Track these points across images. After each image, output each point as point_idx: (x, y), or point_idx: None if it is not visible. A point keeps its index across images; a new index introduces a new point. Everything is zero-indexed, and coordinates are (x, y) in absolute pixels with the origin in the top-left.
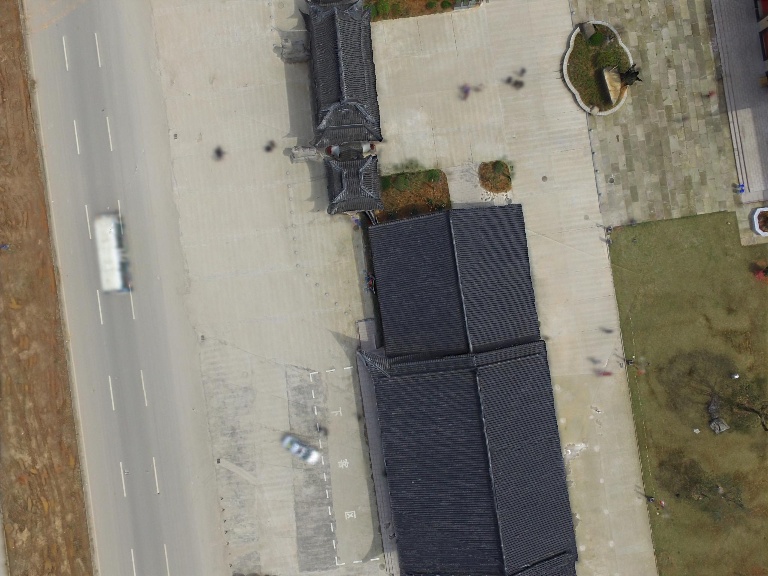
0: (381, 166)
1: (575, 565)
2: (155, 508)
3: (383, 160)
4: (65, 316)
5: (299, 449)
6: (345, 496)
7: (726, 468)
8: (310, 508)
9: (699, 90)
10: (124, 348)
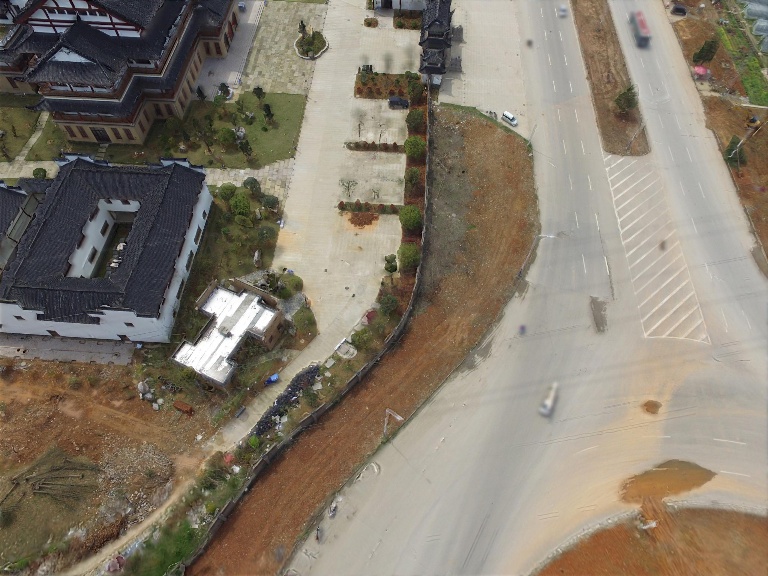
0: None
1: None
2: None
3: None
4: None
5: None
6: None
7: None
8: None
9: None
10: (546, 1)
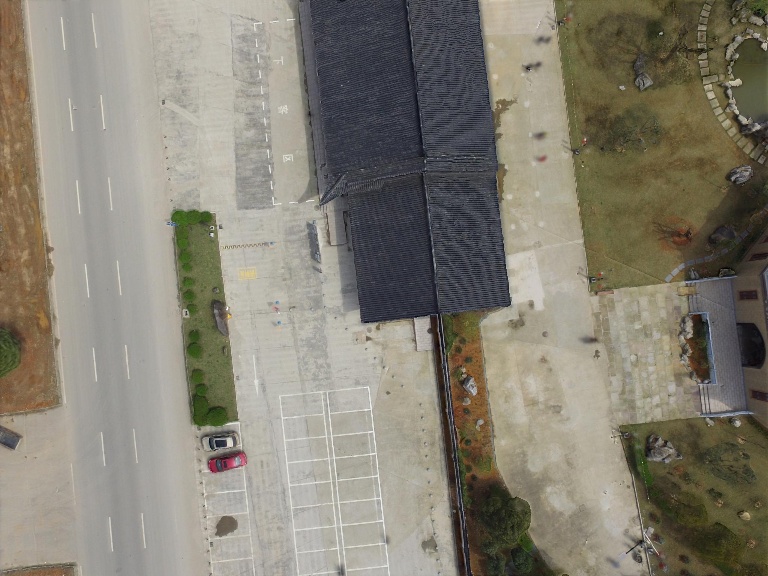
0: None
1: (502, 212)
2: (101, 143)
3: None
4: None
5: (241, 94)
6: (284, 140)
7: None
8: (250, 150)
9: None
10: None
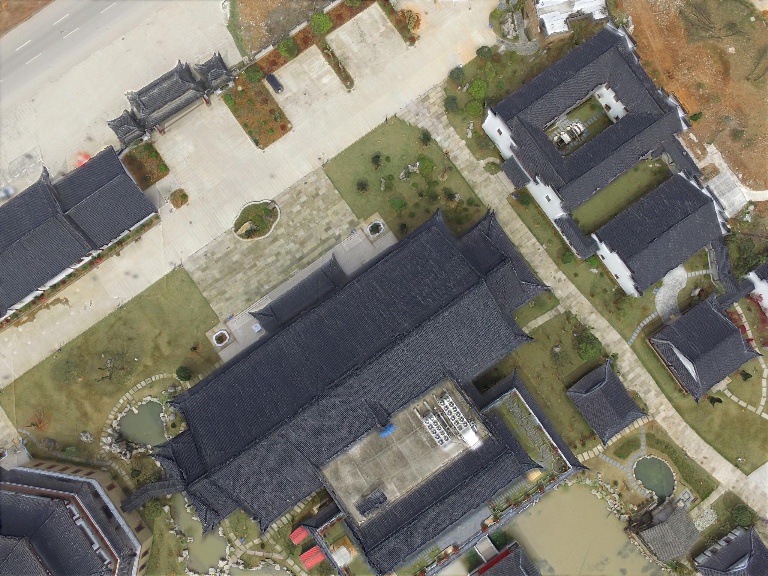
0: (157, 142)
1: (10, 330)
2: None
3: (161, 141)
4: (11, 31)
5: (2, 172)
6: None
7: (92, 378)
8: None
9: (272, 275)
10: (9, 66)
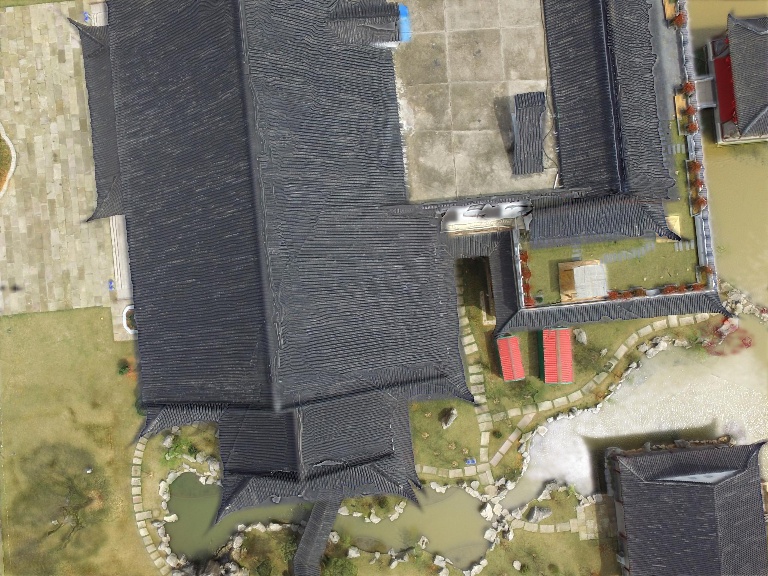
0: None
1: None
2: None
3: None
4: None
5: None
6: None
7: (81, 560)
8: None
9: (83, 185)
10: None
